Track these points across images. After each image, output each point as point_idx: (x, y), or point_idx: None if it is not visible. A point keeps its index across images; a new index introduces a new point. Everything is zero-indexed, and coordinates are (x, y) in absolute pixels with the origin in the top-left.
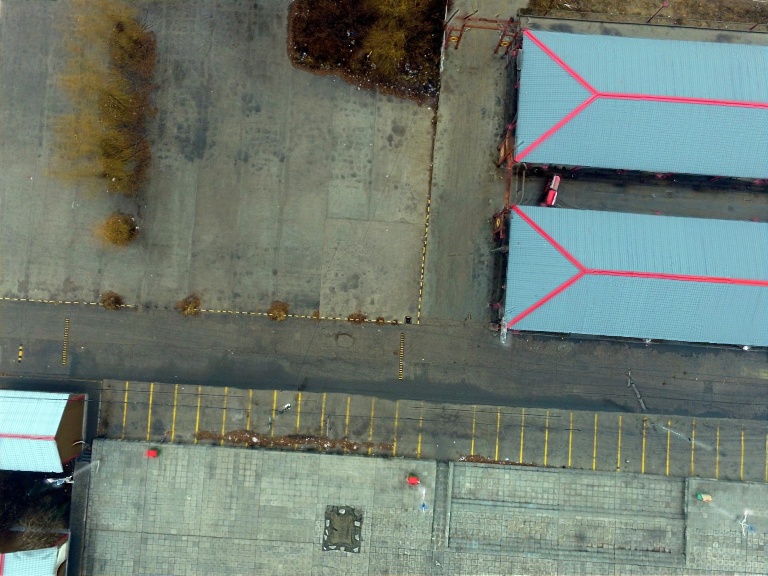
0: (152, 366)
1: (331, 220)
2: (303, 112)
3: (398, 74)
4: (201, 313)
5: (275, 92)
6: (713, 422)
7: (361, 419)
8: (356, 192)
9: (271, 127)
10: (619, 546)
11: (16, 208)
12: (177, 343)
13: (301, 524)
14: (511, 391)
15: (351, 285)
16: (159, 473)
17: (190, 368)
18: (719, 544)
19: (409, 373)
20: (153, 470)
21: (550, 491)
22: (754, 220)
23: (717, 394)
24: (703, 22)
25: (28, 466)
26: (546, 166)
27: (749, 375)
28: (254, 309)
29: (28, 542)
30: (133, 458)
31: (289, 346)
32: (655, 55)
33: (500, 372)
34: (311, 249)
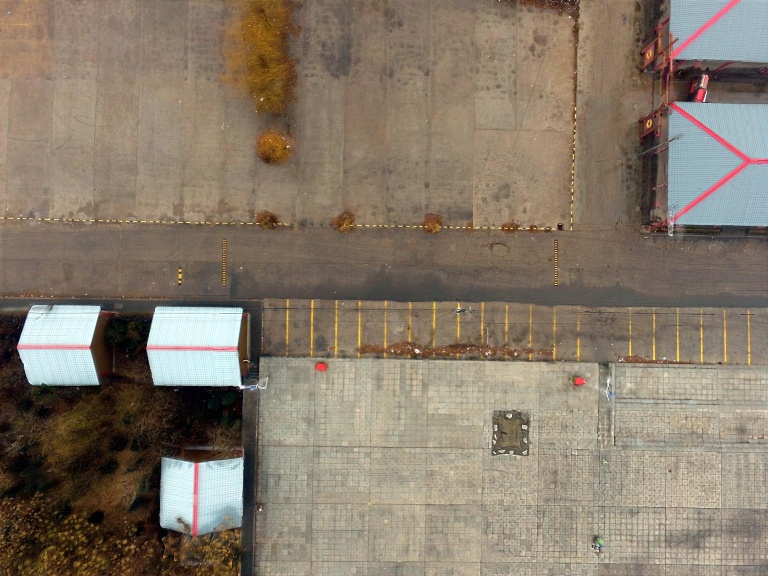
0: (311, 283)
1: (479, 131)
2: (445, 25)
3: None
4: (356, 229)
5: (417, 6)
6: None
7: (520, 326)
8: (502, 103)
9: (415, 41)
10: None
11: (167, 132)
12: (335, 259)
13: (470, 430)
14: (665, 292)
15: (503, 195)
16: (327, 387)
17: (349, 284)
18: None
19: (564, 279)
20: (321, 384)
21: (709, 387)
22: None
23: None
24: None
25: (207, 381)
26: (699, 63)
27: None
28: (409, 222)
29: (219, 451)
30: (300, 373)
31: (445, 257)
32: None
33: (653, 274)
34: (461, 161)
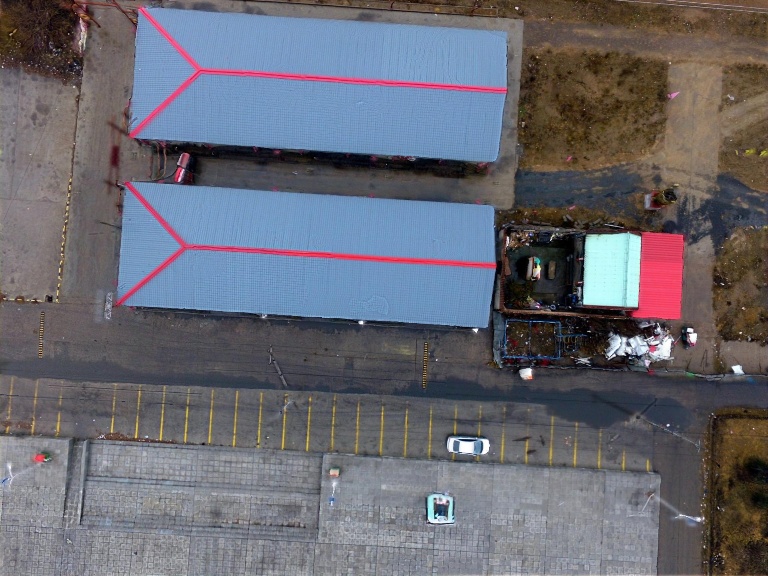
0: None
1: None
2: None
3: (42, 52)
4: None
5: None
6: (353, 398)
7: None
8: None
9: None
10: (254, 522)
11: None
12: None
13: None
14: (152, 369)
15: None
16: None
17: None
18: (351, 518)
19: (49, 352)
20: None
21: (188, 468)
22: (370, 196)
23: (358, 370)
24: (345, 0)
25: None
26: (163, 143)
27: (389, 351)
28: None
29: None
30: None
31: None
32: (267, 31)
33: (141, 350)
34: None
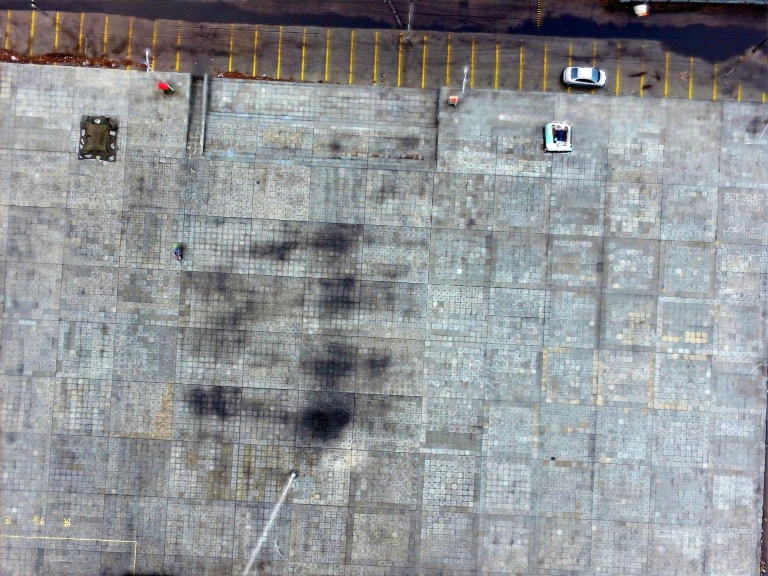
0: None
1: None
2: None
3: None
4: None
5: None
6: (468, 36)
7: (119, 38)
8: None
9: None
10: (373, 154)
11: None
12: None
13: (57, 134)
14: (268, 9)
15: None
16: None
17: None
18: (469, 148)
19: None
20: None
21: (306, 104)
22: None
23: (472, 9)
24: None
25: None
26: None
27: None
28: None
29: None
30: None
31: None
32: None
33: None
34: None
